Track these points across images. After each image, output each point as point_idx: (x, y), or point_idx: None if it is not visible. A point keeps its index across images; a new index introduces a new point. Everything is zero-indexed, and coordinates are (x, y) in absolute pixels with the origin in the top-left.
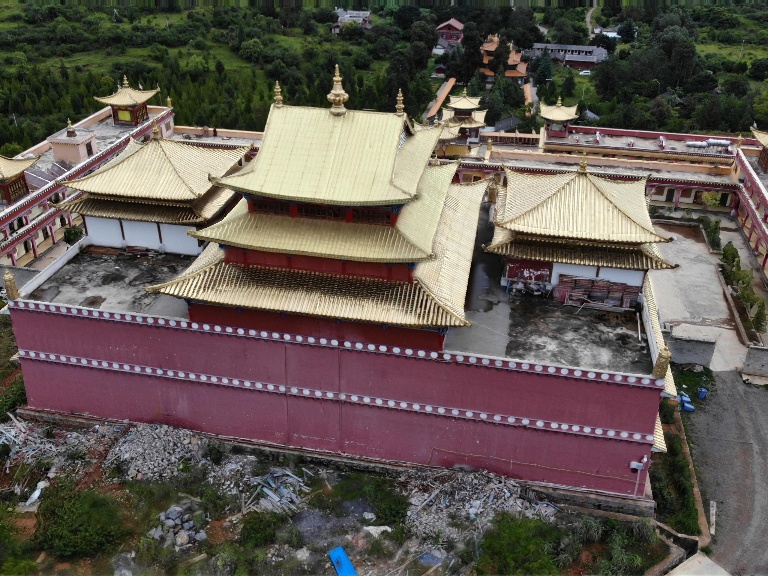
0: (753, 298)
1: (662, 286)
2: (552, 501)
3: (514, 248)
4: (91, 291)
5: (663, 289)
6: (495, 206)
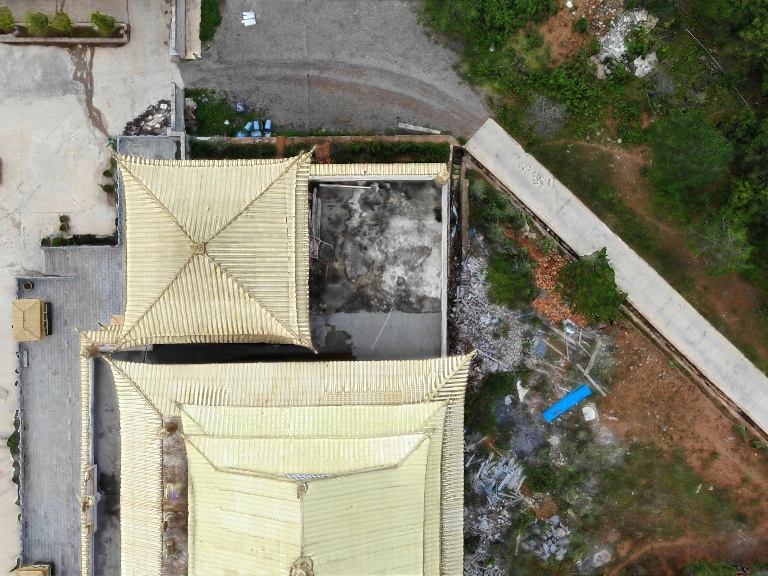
0: (67, 21)
1: (7, 118)
2: (453, 259)
3: (299, 318)
4: None
5: (15, 118)
6: None
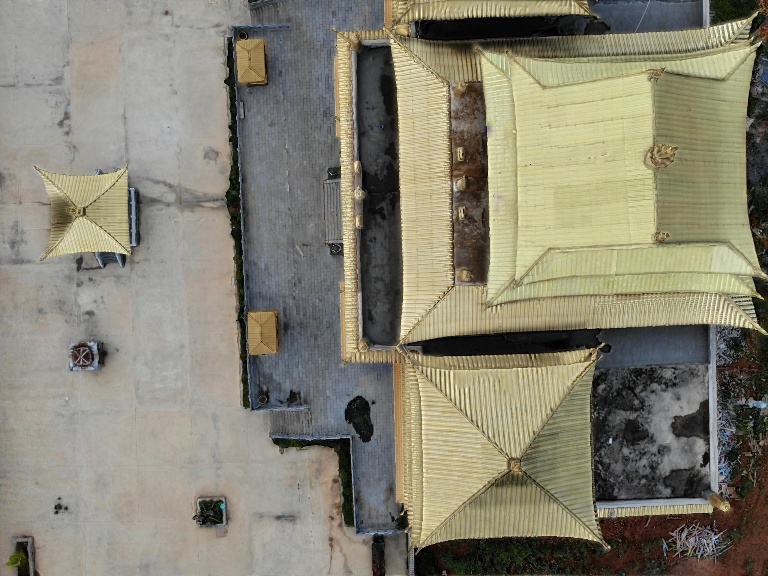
0: None
1: None
2: None
3: None
4: (665, 440)
5: None
6: (5, 112)
